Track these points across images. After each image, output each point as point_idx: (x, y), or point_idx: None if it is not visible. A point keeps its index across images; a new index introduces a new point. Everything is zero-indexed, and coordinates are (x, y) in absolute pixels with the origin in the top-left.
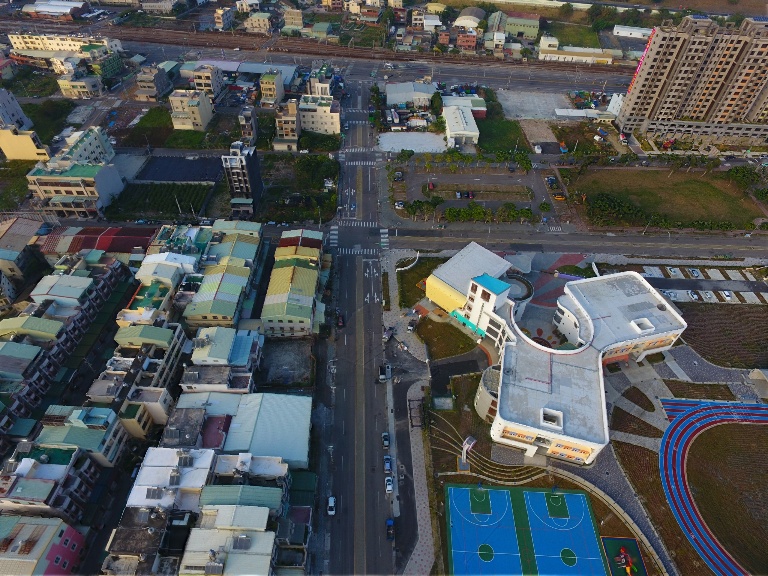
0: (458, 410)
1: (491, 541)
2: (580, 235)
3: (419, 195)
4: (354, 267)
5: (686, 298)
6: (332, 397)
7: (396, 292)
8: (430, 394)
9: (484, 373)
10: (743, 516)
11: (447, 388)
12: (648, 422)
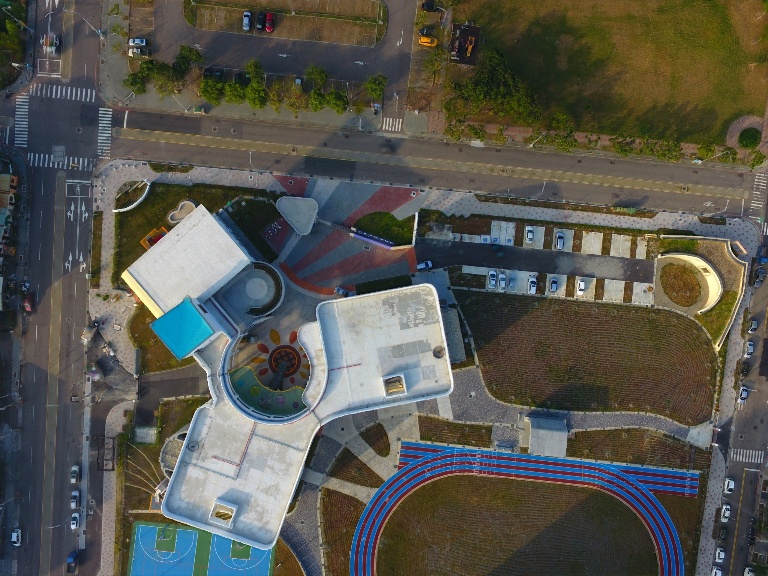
0: (161, 444)
1: (167, 575)
2: (426, 142)
3: (176, 16)
4: (51, 198)
5: (522, 287)
6: (19, 416)
7: (110, 254)
8: (132, 422)
9: (165, 444)
10: (418, 567)
11: (154, 415)
12: (373, 469)
